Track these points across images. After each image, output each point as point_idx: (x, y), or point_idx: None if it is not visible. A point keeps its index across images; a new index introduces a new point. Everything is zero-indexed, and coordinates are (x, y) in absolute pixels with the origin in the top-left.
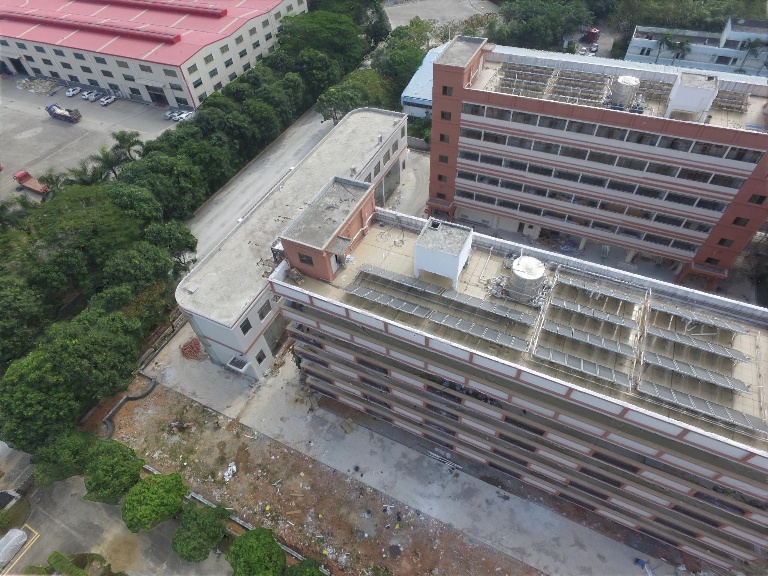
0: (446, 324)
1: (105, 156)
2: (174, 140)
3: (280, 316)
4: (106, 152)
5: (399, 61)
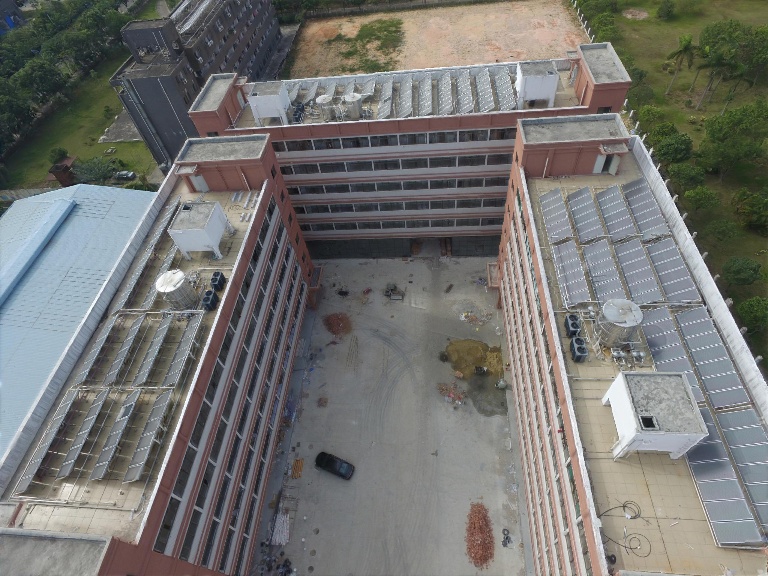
0: None
1: None
2: None
3: None
4: None
5: None
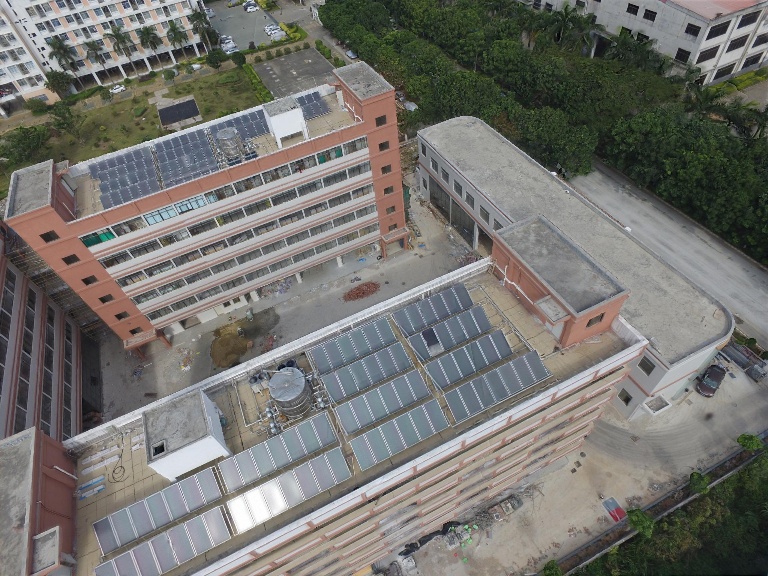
0: (253, 112)
1: None
2: None
3: None
4: (745, 106)
5: None
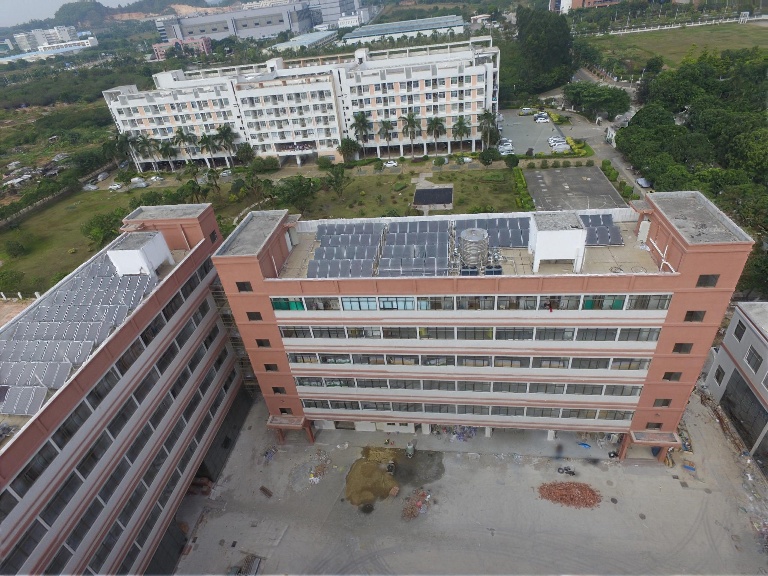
0: (515, 218)
1: None
2: None
3: (752, 398)
4: None
5: None
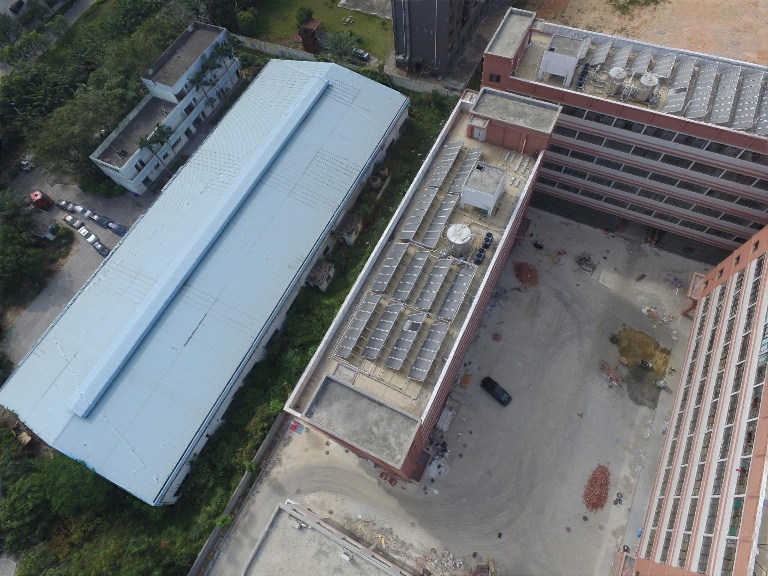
0: None
1: None
2: None
3: None
4: None
5: (36, 503)
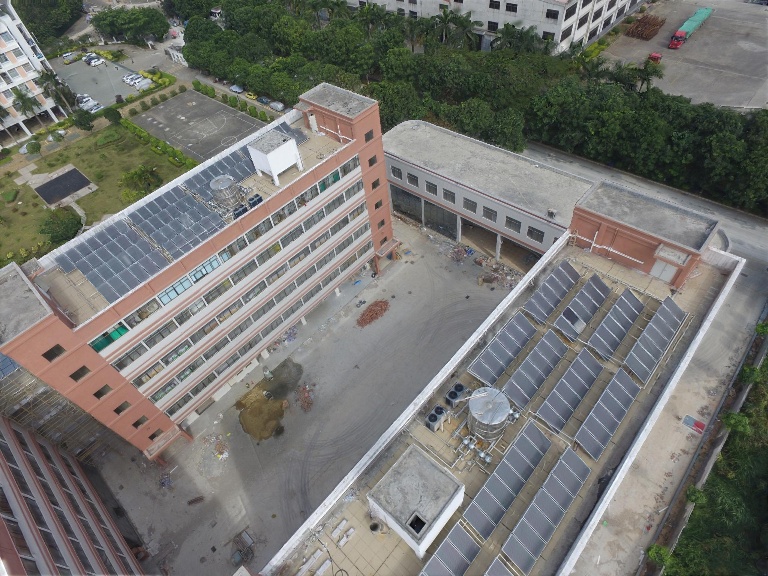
0: (226, 156)
1: (623, 69)
2: (664, 104)
3: (408, 195)
4: (627, 67)
5: None
